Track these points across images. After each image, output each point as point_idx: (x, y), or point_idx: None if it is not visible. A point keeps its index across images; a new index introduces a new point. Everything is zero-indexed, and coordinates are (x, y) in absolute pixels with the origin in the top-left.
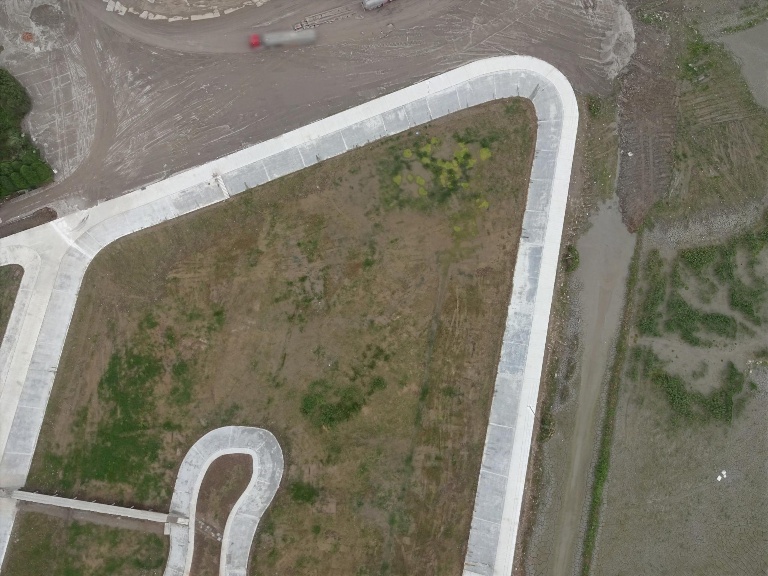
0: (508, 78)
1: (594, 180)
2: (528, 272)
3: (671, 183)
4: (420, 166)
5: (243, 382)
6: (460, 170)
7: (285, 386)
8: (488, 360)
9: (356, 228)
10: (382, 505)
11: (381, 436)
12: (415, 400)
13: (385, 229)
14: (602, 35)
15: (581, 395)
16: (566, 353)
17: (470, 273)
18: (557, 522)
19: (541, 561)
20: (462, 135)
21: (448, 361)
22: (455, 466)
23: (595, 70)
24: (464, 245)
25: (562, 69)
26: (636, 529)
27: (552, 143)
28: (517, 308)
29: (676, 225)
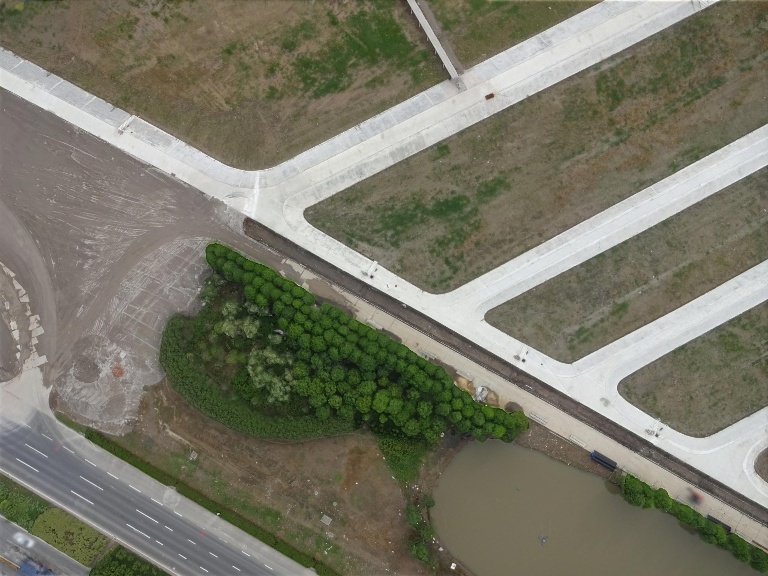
0: None
1: None
2: None
3: None
4: None
5: None
6: None
7: None
8: None
9: (85, 7)
10: None
11: None
12: None
13: None
14: None
15: None
16: None
17: None
18: None
19: None
20: None
21: None
22: None
23: None
24: None
25: None
26: None
27: None
28: None
29: None
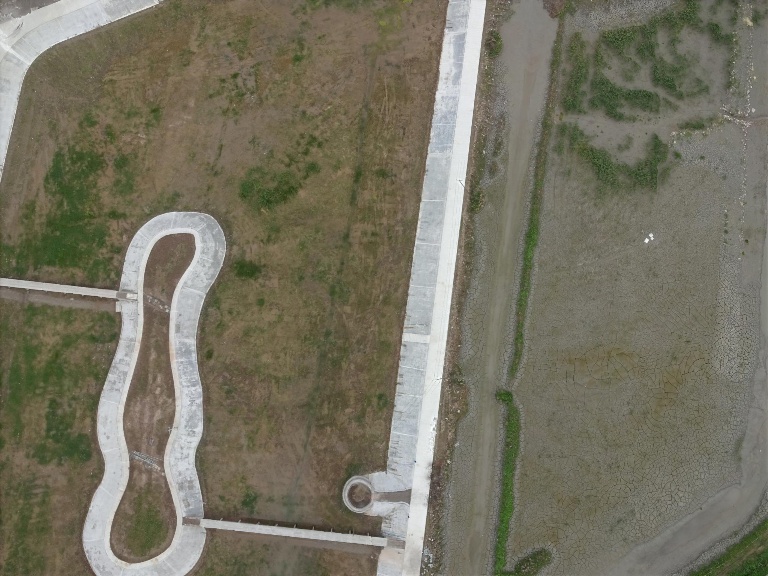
0: None
1: None
2: (453, 58)
3: None
4: None
5: (183, 172)
6: None
7: (223, 174)
8: (418, 143)
9: (284, 27)
10: (322, 278)
11: (318, 216)
12: (349, 182)
13: (312, 26)
14: None
15: (509, 170)
16: (493, 132)
17: (397, 64)
18: (491, 286)
19: (477, 321)
20: None
21: (379, 145)
22: (391, 240)
23: None
24: (390, 38)
25: None
26: (567, 289)
27: None
28: (444, 92)
29: (597, 9)
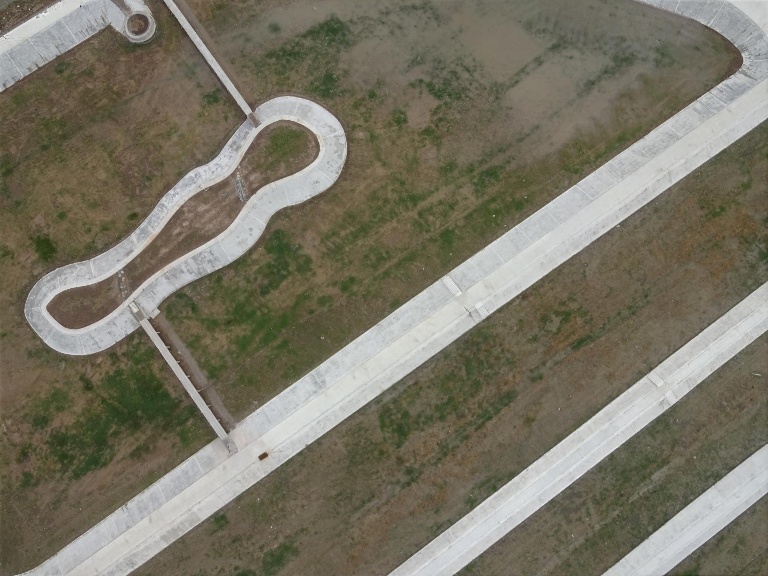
0: None
1: None
2: None
3: None
4: None
5: (8, 368)
6: None
7: None
8: None
9: None
10: (4, 188)
11: None
12: None
13: None
14: None
15: None
16: None
17: None
18: None
19: None
20: None
21: None
22: None
23: None
24: None
25: None
26: None
27: None
28: None
29: None
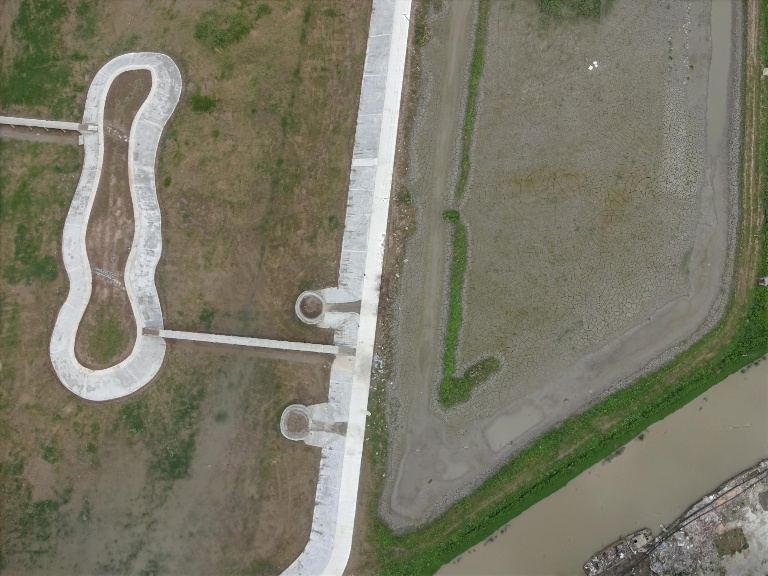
0: None
1: None
2: None
3: None
4: None
5: (140, 17)
6: None
7: (178, 18)
8: None
9: None
10: (274, 111)
11: (270, 54)
12: (299, 22)
13: None
14: None
15: (454, 5)
16: None
17: None
18: (437, 113)
19: (424, 146)
20: None
21: None
22: (340, 75)
23: None
24: None
25: None
26: (512, 115)
27: None
28: None
29: None
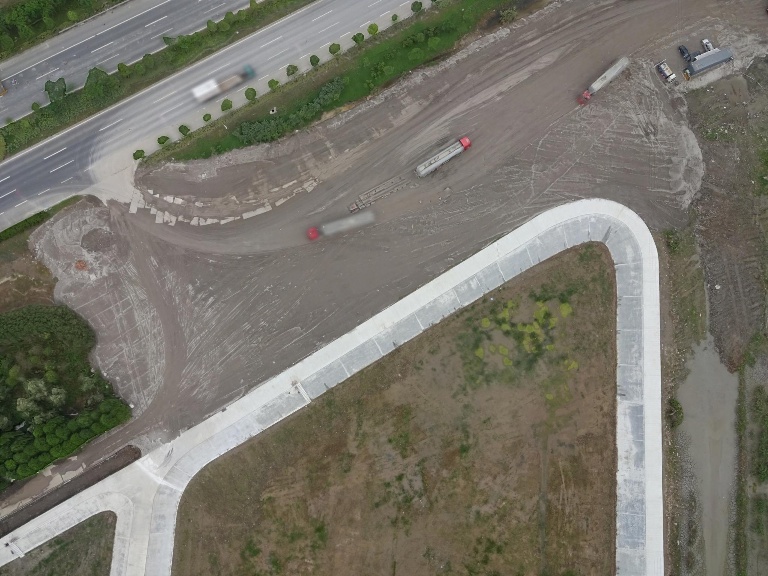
0: (578, 225)
1: (684, 322)
2: (631, 434)
3: (765, 311)
4: (500, 334)
5: None
6: (542, 332)
7: None
8: (604, 535)
9: (445, 413)
10: None
11: None
12: None
13: (475, 409)
14: (668, 162)
15: (707, 559)
16: (685, 516)
17: (570, 443)
18: None
19: None
20: (538, 293)
21: (563, 543)
22: None
23: (667, 201)
24: (559, 413)
25: (633, 206)
26: None
27: (634, 289)
28: (626, 475)
29: None
